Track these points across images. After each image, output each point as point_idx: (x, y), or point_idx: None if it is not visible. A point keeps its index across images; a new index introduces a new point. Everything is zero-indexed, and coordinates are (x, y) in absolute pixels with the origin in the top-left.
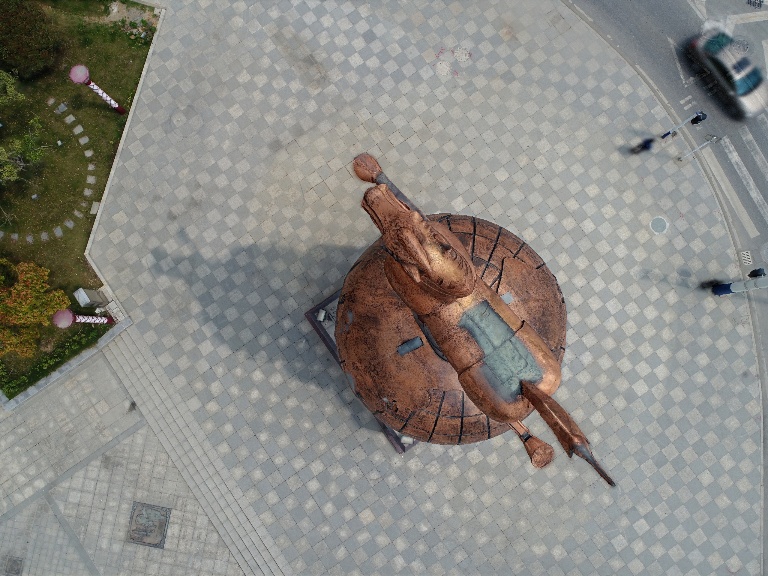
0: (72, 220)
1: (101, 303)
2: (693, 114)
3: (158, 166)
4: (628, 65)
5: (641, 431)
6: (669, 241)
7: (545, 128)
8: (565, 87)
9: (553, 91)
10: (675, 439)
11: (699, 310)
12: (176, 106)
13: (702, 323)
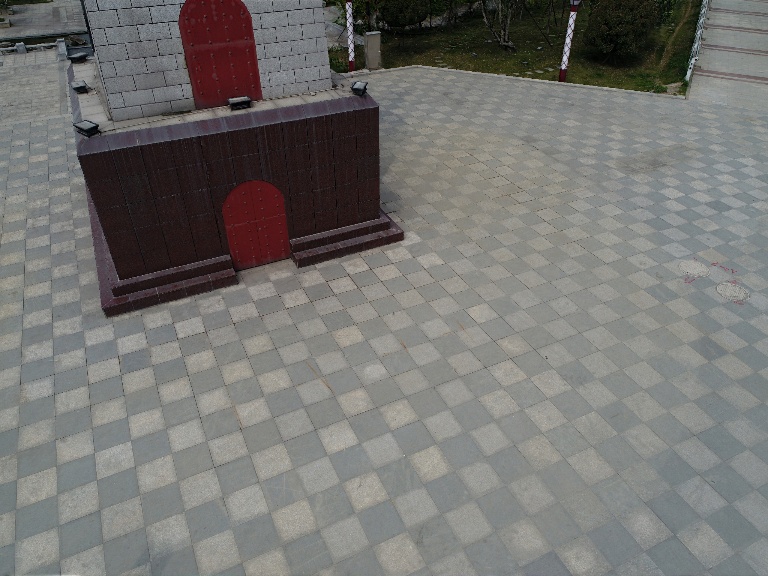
0: (452, 68)
1: (368, 58)
2: None
3: (503, 91)
4: None
5: None
6: None
7: (596, 392)
8: (722, 448)
9: (701, 421)
10: None
11: None
12: (571, 100)
13: None
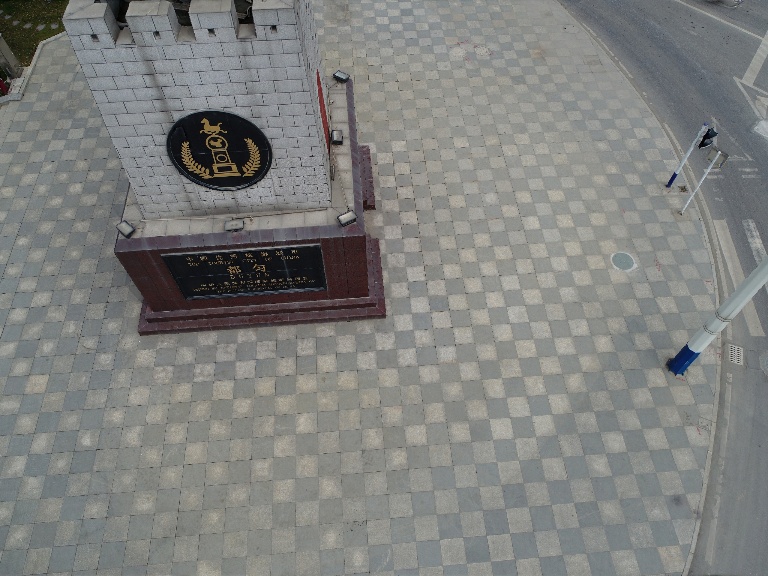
0: (59, 24)
1: (10, 67)
2: (716, 185)
3: None
4: (654, 118)
5: (470, 488)
6: (629, 283)
7: (533, 127)
8: (574, 107)
9: (559, 105)
10: (518, 531)
11: (637, 377)
12: None
13: (635, 395)
